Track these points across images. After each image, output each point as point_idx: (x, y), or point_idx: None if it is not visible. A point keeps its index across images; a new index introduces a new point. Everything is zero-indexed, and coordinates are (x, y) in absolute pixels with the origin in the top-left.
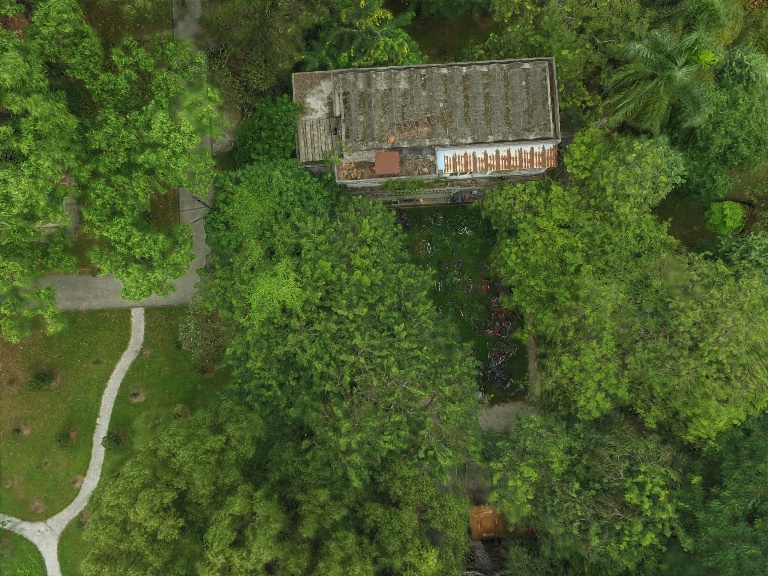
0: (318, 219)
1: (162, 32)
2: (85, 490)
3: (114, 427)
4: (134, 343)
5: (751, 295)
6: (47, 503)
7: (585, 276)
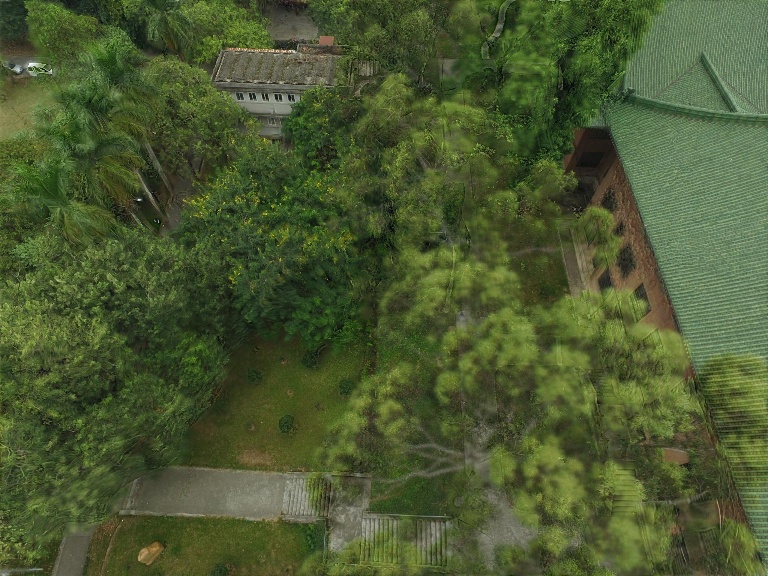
0: (367, 2)
1: (479, 177)
2: (507, 4)
3: (495, 21)
4: (487, 47)
5: (141, 6)
6: (526, 2)
7: (229, 8)
